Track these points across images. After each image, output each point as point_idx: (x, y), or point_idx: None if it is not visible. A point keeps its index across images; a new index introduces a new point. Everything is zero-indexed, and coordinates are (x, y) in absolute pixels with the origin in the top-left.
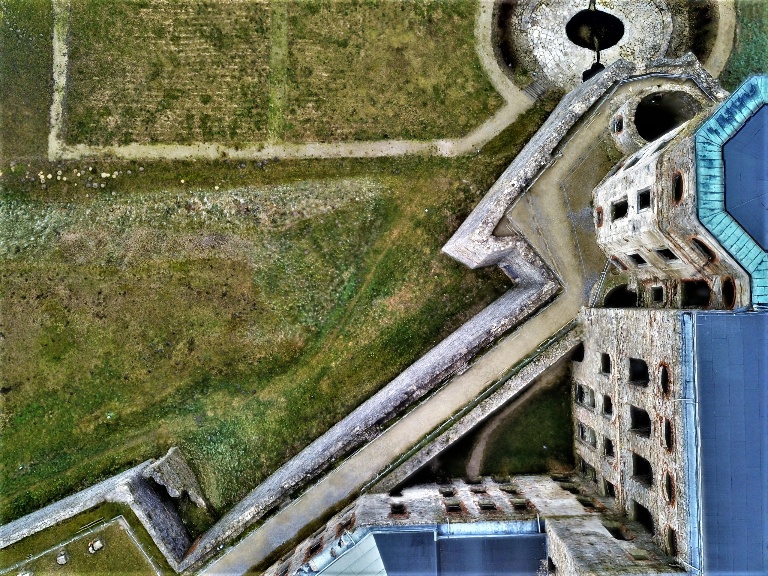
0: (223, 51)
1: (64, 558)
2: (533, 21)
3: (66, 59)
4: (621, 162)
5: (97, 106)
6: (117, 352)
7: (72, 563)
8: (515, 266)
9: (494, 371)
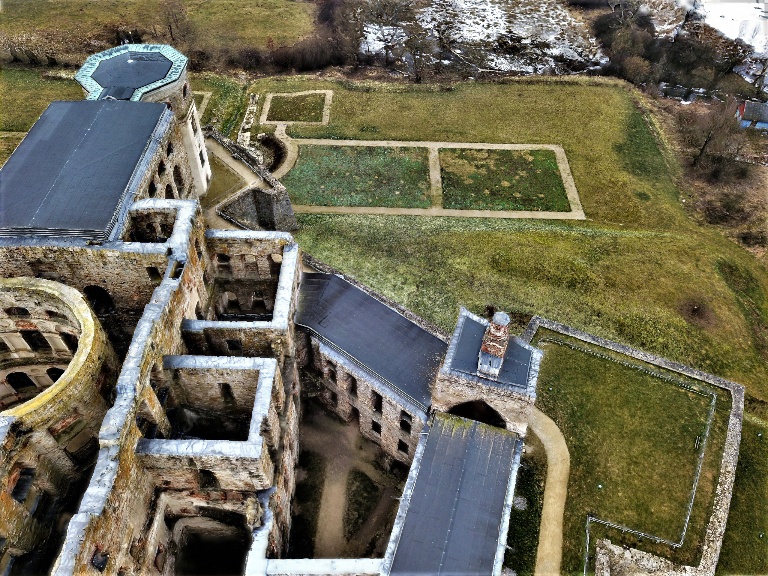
0: None
1: None
2: None
3: None
4: None
5: None
6: None
7: None
8: None
9: None
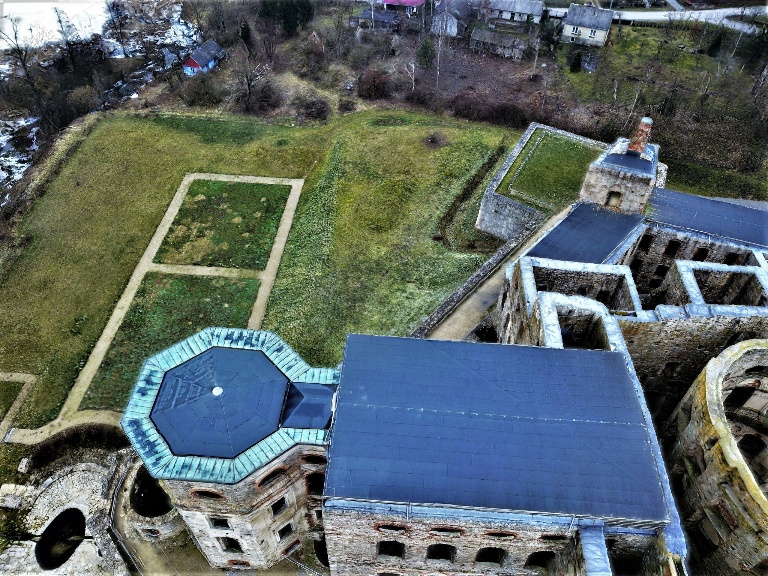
0: None
1: None
2: None
3: None
4: (190, 534)
5: None
6: None
7: None
8: None
9: None
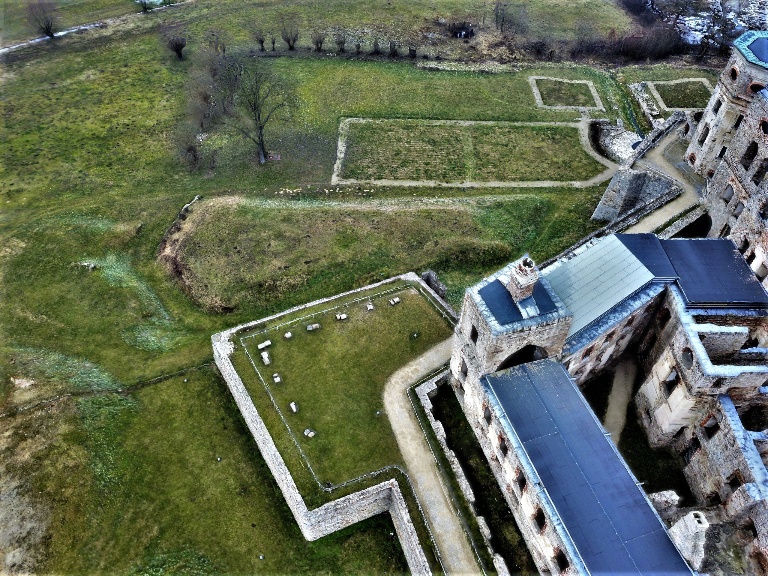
0: (436, 147)
1: (372, 305)
2: (612, 144)
3: (345, 148)
4: None
5: (362, 165)
6: (387, 244)
7: (377, 310)
8: (647, 199)
9: (655, 224)
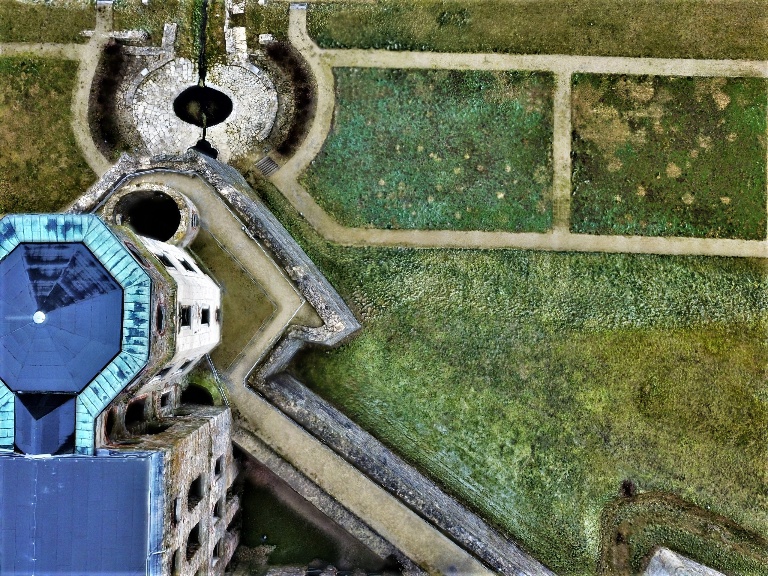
0: None
1: None
2: (139, 96)
3: None
4: None
5: None
6: None
7: None
8: None
9: None
